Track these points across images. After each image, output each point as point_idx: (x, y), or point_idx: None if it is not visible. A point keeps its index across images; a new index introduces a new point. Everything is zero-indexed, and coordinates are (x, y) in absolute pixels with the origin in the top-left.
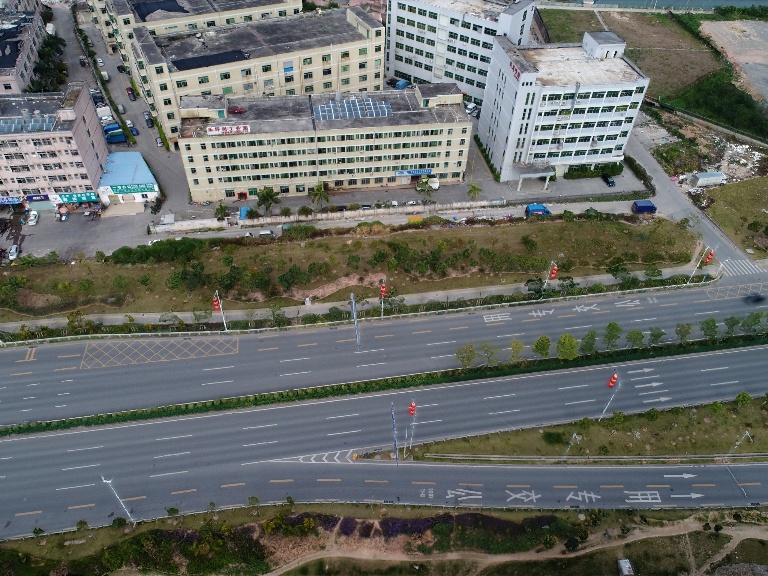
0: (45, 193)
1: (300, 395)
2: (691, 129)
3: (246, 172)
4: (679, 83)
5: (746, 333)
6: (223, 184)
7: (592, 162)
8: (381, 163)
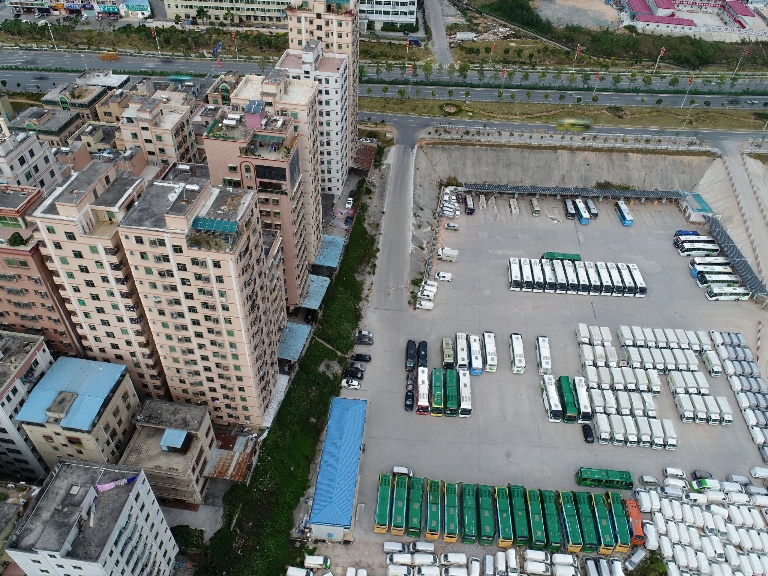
0: (92, 4)
1: (182, 74)
2: (482, 20)
3: (195, 3)
4: (495, 0)
5: (418, 80)
6: (183, 9)
7: (396, 21)
8: (270, 6)
